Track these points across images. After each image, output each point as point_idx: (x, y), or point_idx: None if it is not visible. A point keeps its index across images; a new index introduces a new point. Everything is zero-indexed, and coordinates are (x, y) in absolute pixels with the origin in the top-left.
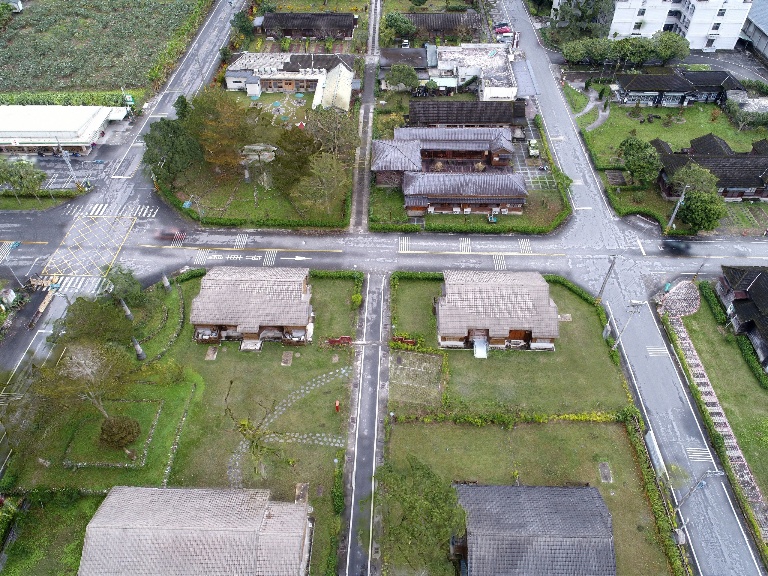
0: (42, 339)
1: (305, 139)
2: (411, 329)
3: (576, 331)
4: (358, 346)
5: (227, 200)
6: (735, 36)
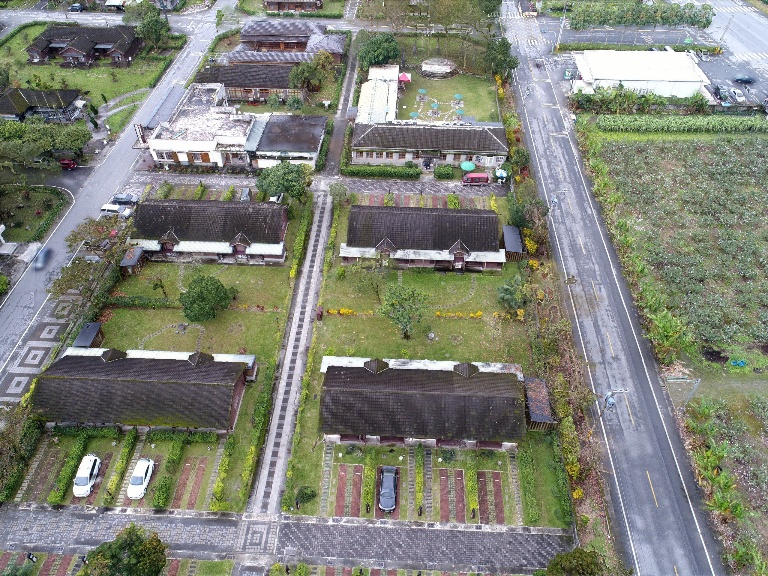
0: (509, 0)
1: None
2: None
3: (256, 2)
4: (361, 0)
5: (448, 44)
6: None
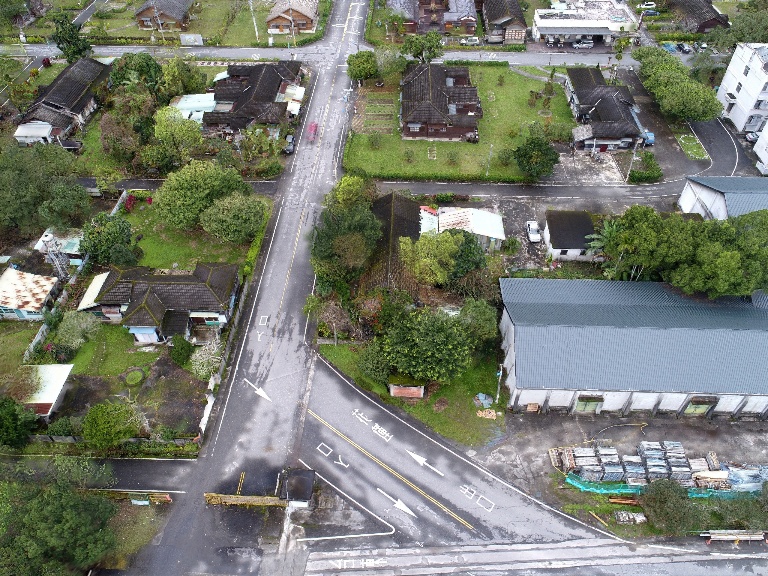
0: None
1: None
2: None
3: None
4: None
5: None
6: None
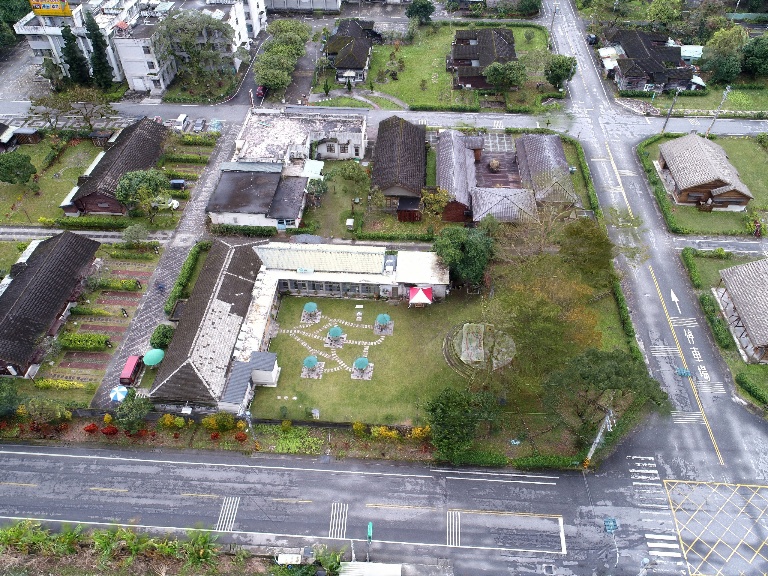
0: None
1: (595, 223)
2: (734, 225)
3: None
4: None
5: None
6: (264, 7)
